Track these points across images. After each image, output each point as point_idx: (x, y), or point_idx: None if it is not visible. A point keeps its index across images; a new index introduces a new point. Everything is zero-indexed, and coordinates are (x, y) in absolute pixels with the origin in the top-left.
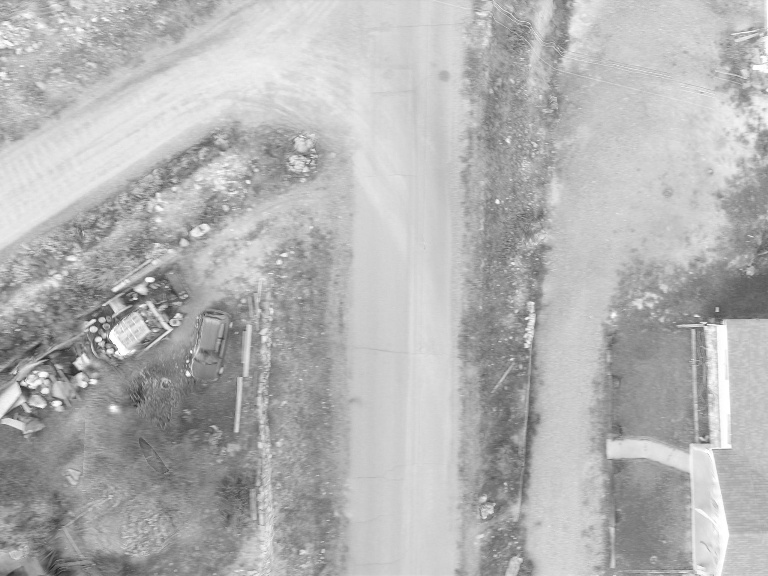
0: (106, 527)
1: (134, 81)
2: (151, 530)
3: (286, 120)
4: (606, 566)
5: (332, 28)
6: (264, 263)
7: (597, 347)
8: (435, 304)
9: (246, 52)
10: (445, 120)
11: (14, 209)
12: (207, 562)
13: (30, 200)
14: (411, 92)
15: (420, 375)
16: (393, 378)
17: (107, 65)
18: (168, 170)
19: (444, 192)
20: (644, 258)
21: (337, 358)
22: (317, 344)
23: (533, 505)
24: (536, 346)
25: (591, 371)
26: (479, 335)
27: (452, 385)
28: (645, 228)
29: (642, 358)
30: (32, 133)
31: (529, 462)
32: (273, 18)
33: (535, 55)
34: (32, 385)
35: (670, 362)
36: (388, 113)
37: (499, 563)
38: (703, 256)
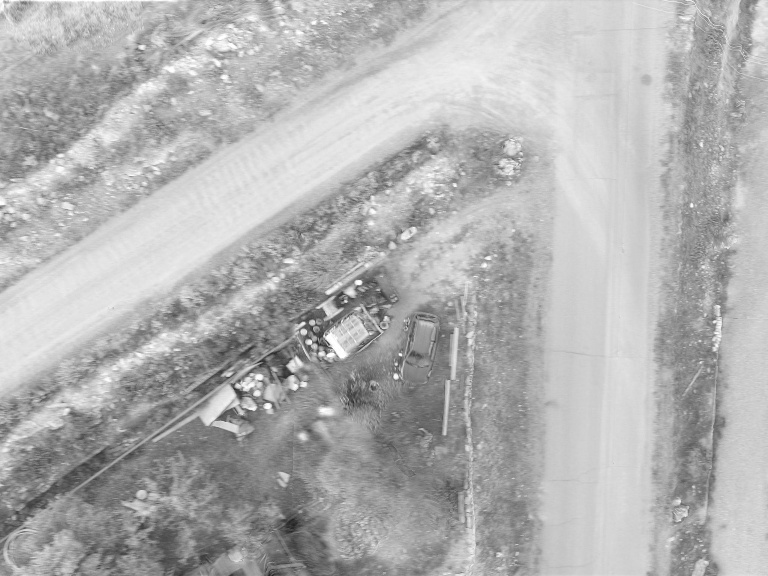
0: (319, 530)
1: (346, 84)
2: (364, 533)
3: (492, 123)
4: None
5: (538, 31)
6: (469, 266)
7: None
8: (632, 307)
9: (454, 55)
10: (646, 124)
11: (230, 212)
12: (415, 565)
13: (246, 203)
14: (613, 96)
15: (616, 378)
16: (589, 381)
17: (322, 68)
18: (382, 173)
19: (643, 196)
20: None
21: (534, 361)
22: (515, 347)
23: (718, 508)
24: (721, 349)
25: None
26: (674, 338)
27: (647, 388)
28: None
29: None
30: (247, 136)
31: (714, 465)
32: (480, 21)
33: (724, 59)
34: (246, 388)
35: None
36: (590, 117)
37: (686, 566)
38: None
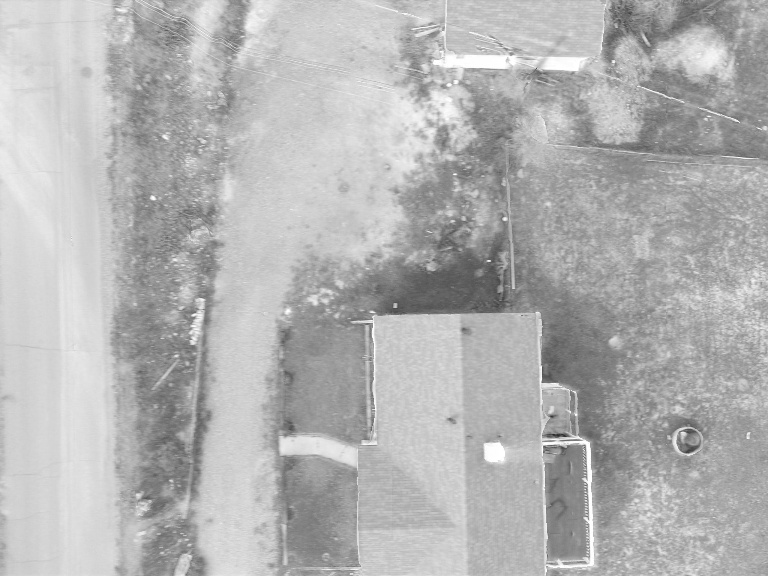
0: None
1: None
2: None
3: None
4: (279, 563)
5: None
6: None
7: (270, 343)
8: (86, 301)
9: None
10: (89, 116)
11: None
12: None
13: None
14: (53, 89)
15: (73, 372)
16: (46, 375)
17: None
18: None
19: (91, 189)
20: (319, 254)
21: None
22: None
23: (204, 502)
24: (208, 343)
25: (264, 368)
26: (133, 332)
27: (106, 382)
28: (320, 224)
29: (315, 354)
30: None
31: (200, 459)
32: None
33: (200, 51)
34: None
35: (343, 358)
36: (30, 110)
37: (167, 560)
38: (379, 252)
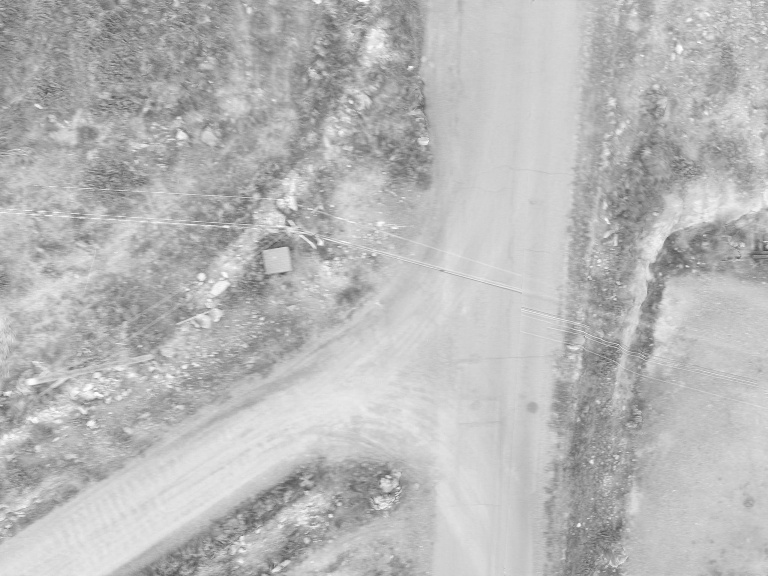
0: None
1: (220, 417)
2: None
3: (371, 452)
4: None
5: (421, 360)
6: None
7: None
8: None
9: (333, 386)
10: (531, 451)
11: (97, 550)
12: None
13: (113, 541)
14: (498, 423)
15: None
16: None
17: (194, 405)
18: (253, 513)
19: (527, 522)
20: (722, 570)
21: None
22: None
23: None
24: None
25: None
26: None
27: None
28: (724, 539)
29: None
30: (117, 472)
31: None
32: (362, 351)
33: (621, 368)
34: None
35: None
36: (473, 443)
37: None
38: None
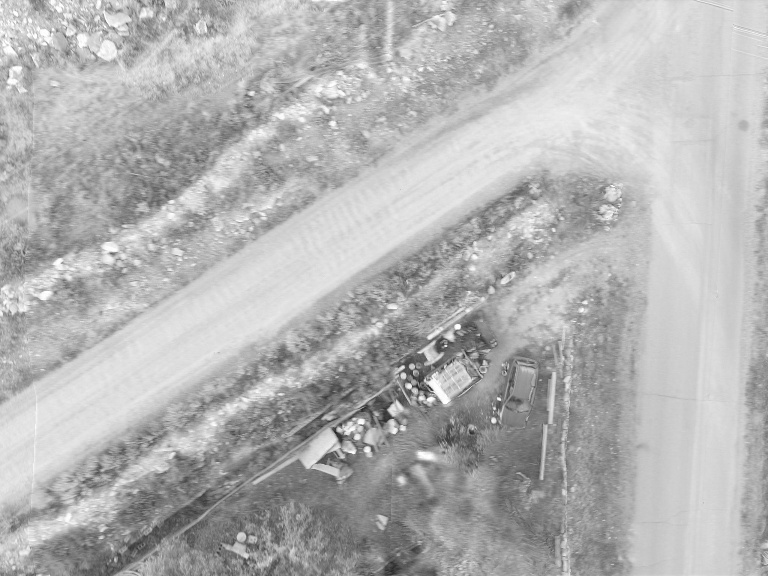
0: (418, 573)
1: (448, 129)
2: None
3: (590, 168)
4: None
5: (637, 77)
6: (566, 311)
7: None
8: (725, 351)
9: (555, 101)
10: (742, 169)
11: (334, 256)
12: None
13: (349, 248)
14: (710, 141)
15: (707, 422)
16: (680, 424)
17: (426, 113)
18: (485, 219)
19: (738, 241)
20: None
21: (627, 404)
22: (608, 390)
23: None
24: None
25: None
26: (765, 382)
27: (738, 432)
28: None
29: None
30: (351, 181)
31: None
32: (581, 67)
33: None
34: (347, 431)
35: None
36: (687, 162)
37: None
38: None
